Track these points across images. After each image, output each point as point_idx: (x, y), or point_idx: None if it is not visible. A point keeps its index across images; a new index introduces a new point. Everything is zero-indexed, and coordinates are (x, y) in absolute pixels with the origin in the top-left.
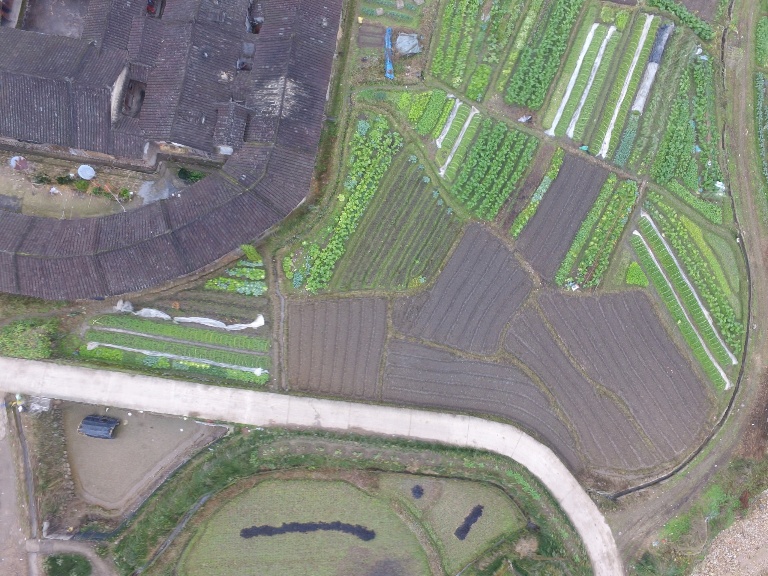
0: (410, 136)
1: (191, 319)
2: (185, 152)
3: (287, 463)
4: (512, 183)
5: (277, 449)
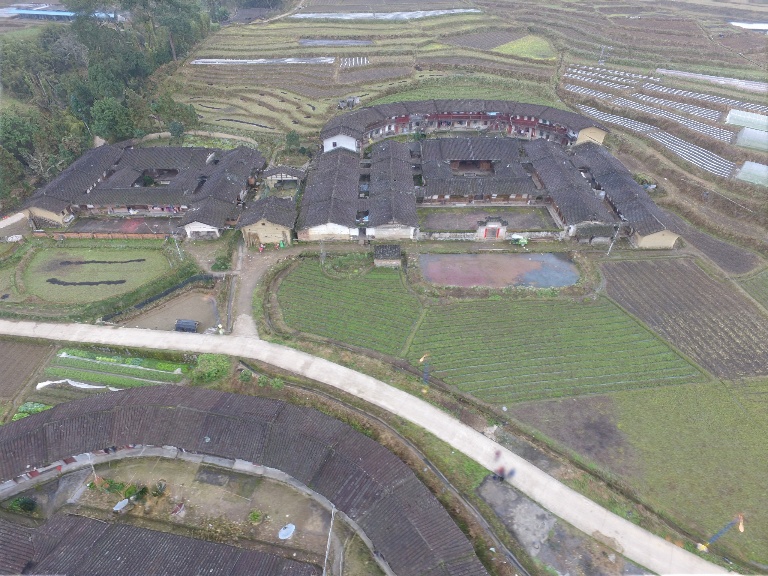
0: None
1: (94, 387)
2: None
3: (69, 305)
4: None
5: (71, 311)
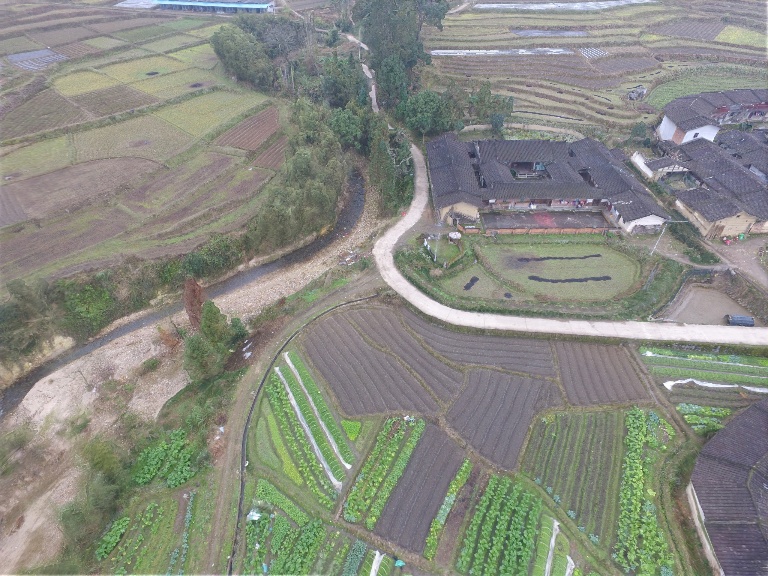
0: (608, 569)
1: (724, 386)
2: None
3: (602, 302)
4: (480, 512)
5: (613, 309)
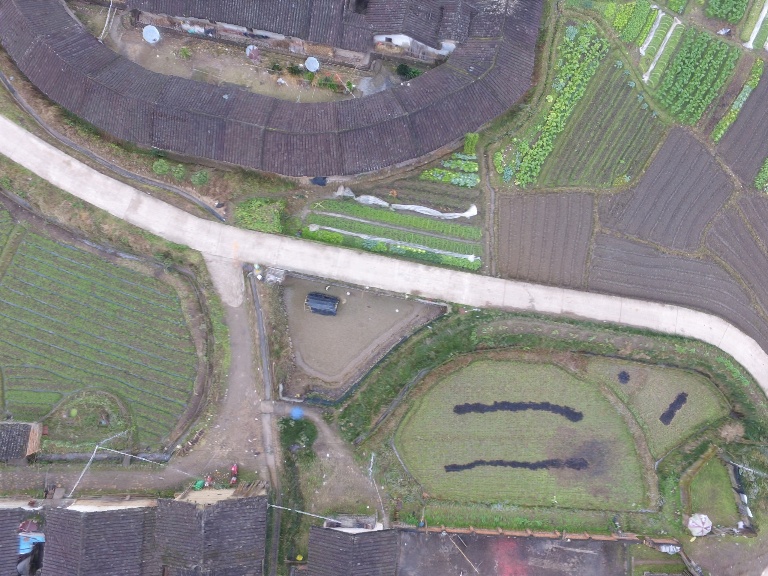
0: (615, 43)
1: (407, 206)
2: (400, 51)
3: (505, 342)
4: (714, 90)
5: (495, 328)
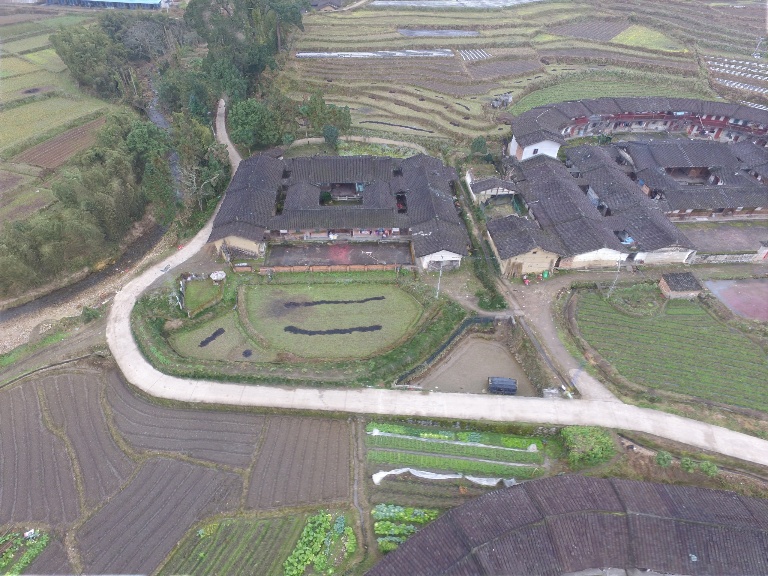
0: None
1: (446, 477)
2: None
3: (346, 363)
4: None
5: (354, 372)
